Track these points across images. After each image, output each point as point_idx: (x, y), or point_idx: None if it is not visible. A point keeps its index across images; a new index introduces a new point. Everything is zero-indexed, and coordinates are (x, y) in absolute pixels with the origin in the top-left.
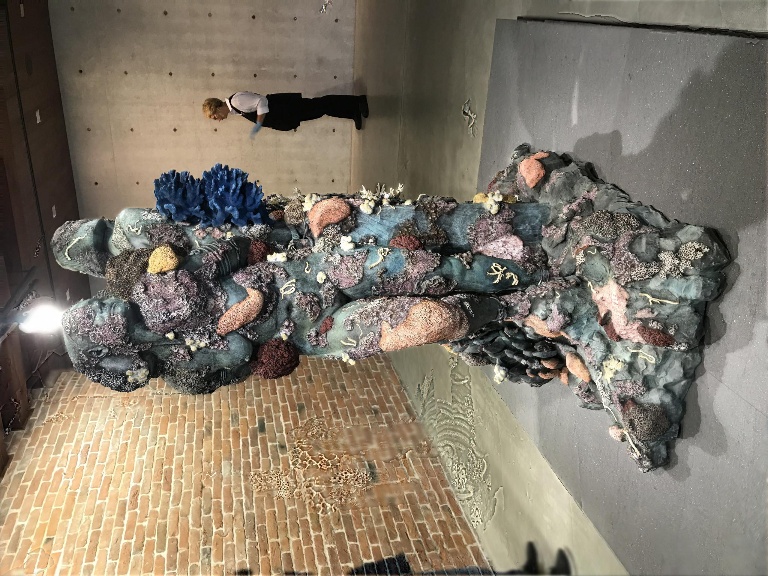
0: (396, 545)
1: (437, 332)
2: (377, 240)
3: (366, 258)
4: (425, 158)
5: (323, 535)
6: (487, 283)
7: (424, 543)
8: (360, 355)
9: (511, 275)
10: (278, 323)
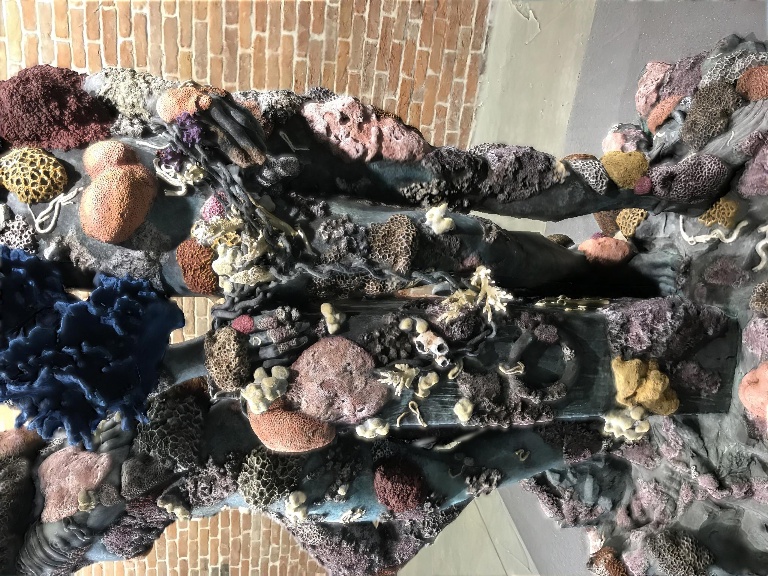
0: None
1: None
2: None
3: None
4: None
5: None
6: None
7: None
8: None
9: None
10: None
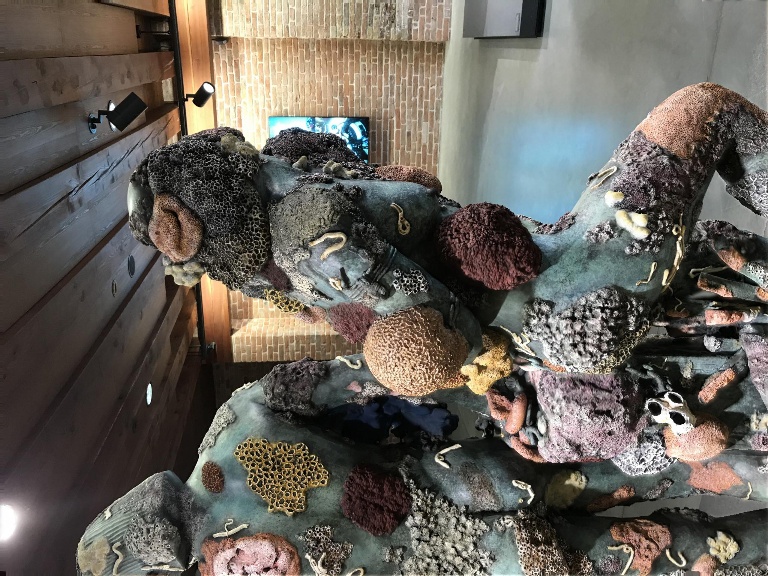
0: None
1: None
2: None
3: None
4: None
5: None
6: None
7: None
8: (638, 183)
9: None
10: None
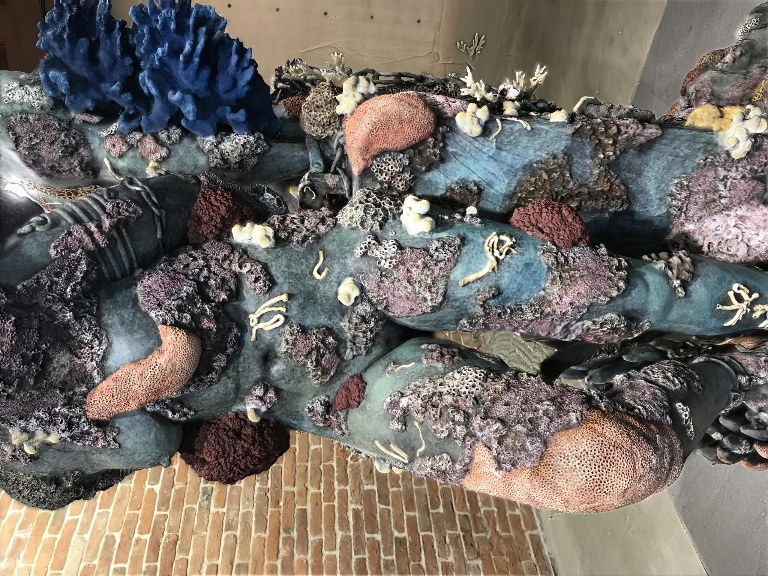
0: (437, 518)
1: (613, 506)
2: (482, 192)
3: (456, 259)
4: (551, 5)
5: (349, 490)
6: (710, 324)
7: (472, 520)
8: None
9: (764, 310)
10: (241, 387)
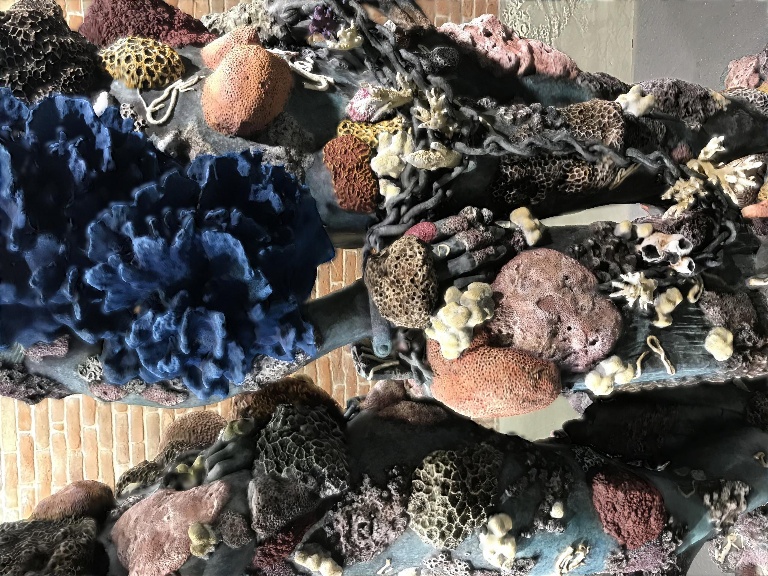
0: None
1: None
2: None
3: None
4: None
5: None
6: None
7: None
8: None
9: None
10: None
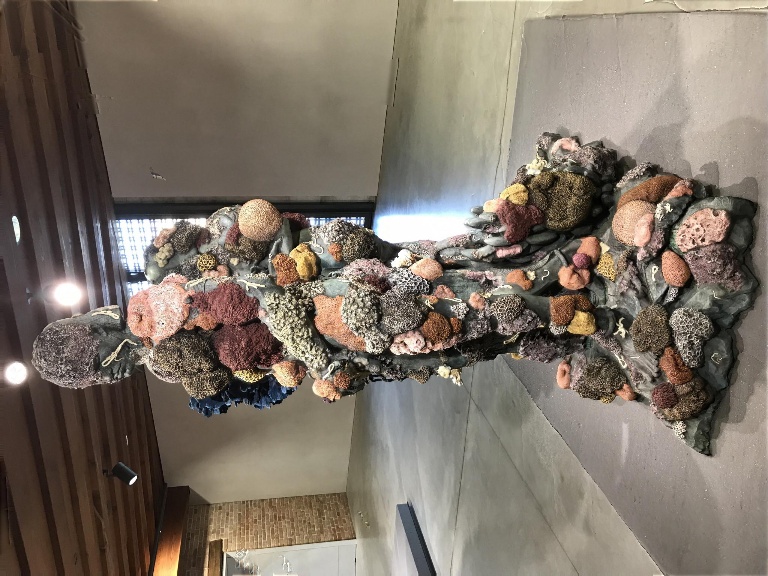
0: None
1: None
2: None
3: None
4: None
5: None
6: None
7: None
8: None
9: None
10: None
